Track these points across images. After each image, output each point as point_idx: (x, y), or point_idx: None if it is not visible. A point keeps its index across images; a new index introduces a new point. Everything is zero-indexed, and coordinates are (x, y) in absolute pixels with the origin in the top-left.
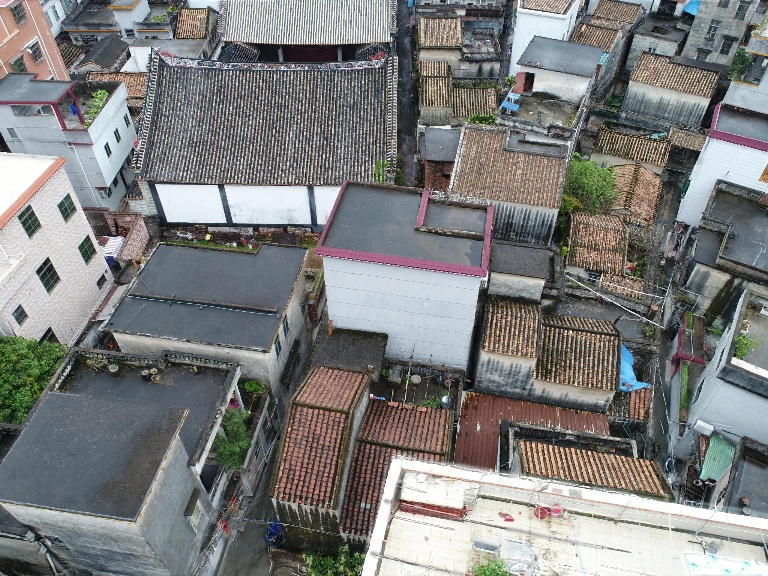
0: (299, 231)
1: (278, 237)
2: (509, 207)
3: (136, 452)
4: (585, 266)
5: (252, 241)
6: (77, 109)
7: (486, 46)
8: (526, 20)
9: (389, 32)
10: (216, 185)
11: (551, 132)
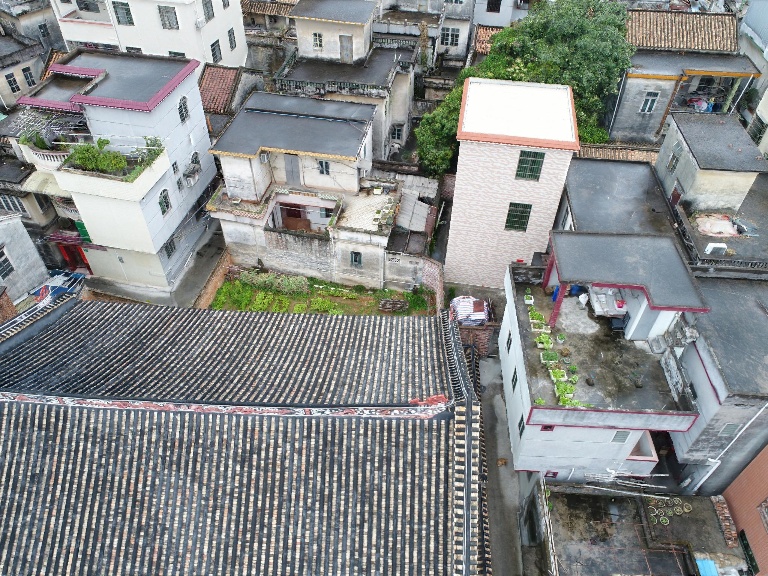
0: None
1: None
2: None
3: (311, 6)
4: None
5: None
6: None
7: None
8: None
9: None
10: None
11: None
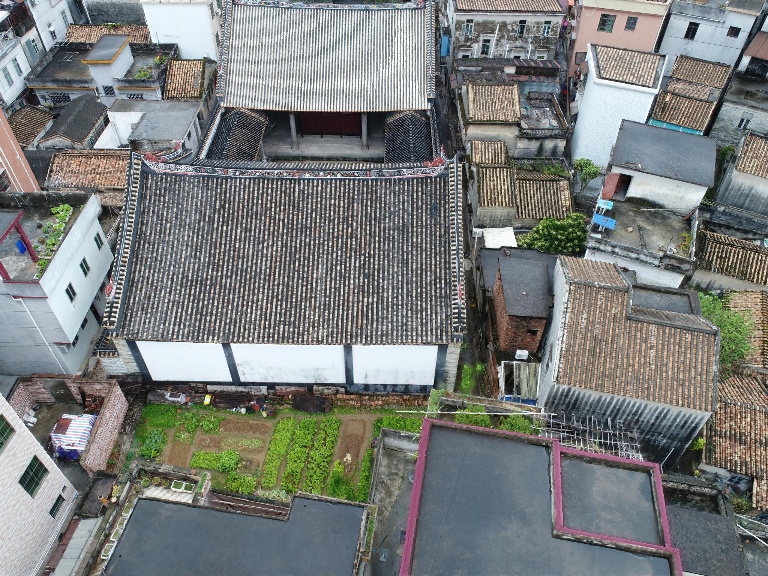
0: (329, 391)
1: (301, 400)
2: (638, 403)
3: None
4: (730, 467)
5: (266, 406)
6: (26, 244)
7: (546, 117)
8: (604, 92)
9: (426, 97)
10: (219, 342)
11: (663, 262)
